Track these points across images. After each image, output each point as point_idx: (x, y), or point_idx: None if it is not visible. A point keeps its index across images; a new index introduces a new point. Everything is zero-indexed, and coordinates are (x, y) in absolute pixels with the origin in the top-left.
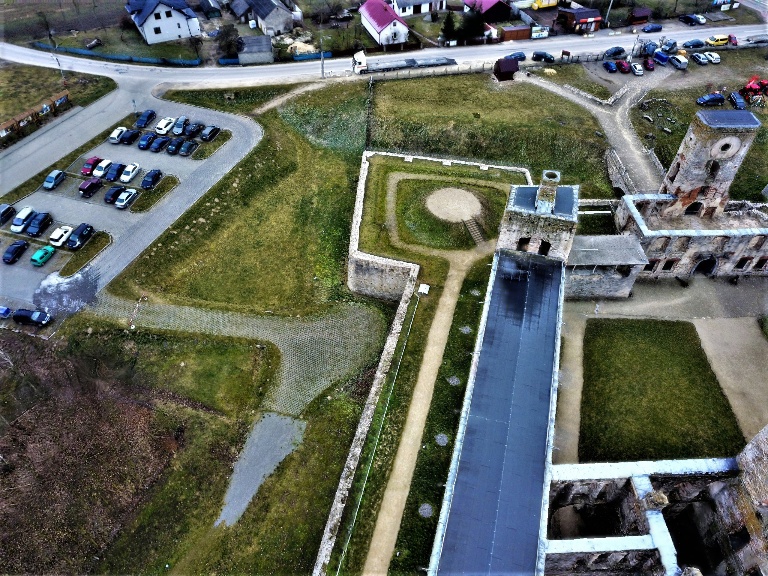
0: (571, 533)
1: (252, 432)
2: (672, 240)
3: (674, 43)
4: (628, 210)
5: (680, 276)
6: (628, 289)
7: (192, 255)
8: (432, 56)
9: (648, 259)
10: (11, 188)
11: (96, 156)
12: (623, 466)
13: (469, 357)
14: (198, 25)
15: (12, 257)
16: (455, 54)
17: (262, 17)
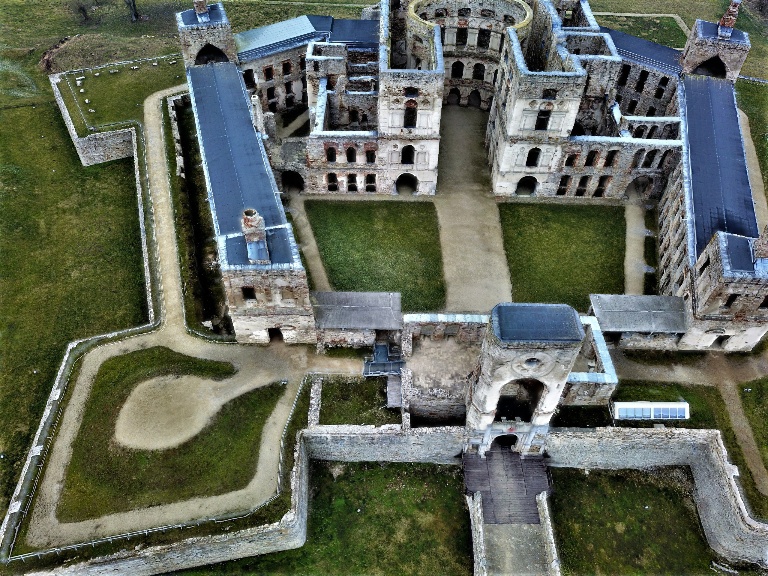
0: (629, 189)
1: None
2: None
3: None
4: None
5: None
6: None
7: None
8: None
9: None
10: None
11: None
12: (639, 141)
13: None
14: None
15: None
16: None
17: None
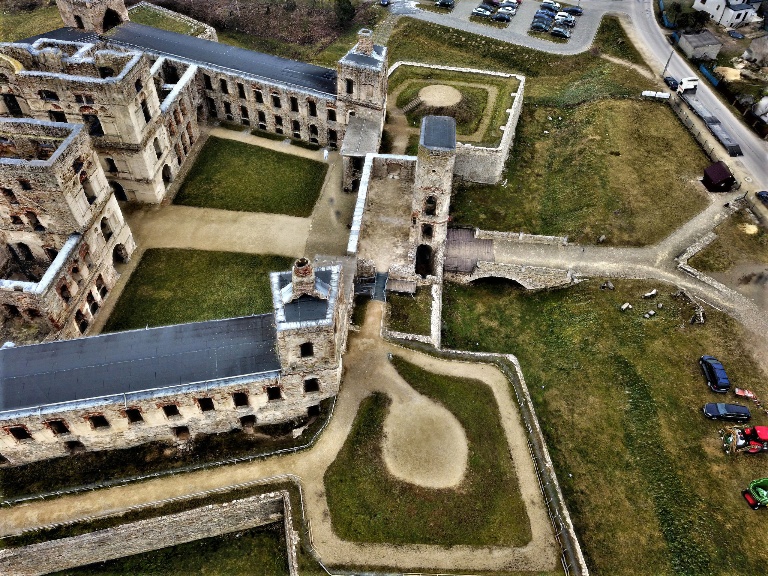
0: None
1: None
2: None
3: None
4: None
5: None
6: None
7: (434, 41)
8: (744, 141)
9: None
10: None
11: (527, 2)
12: (183, 82)
13: None
14: (730, 17)
15: None
16: (759, 159)
17: None
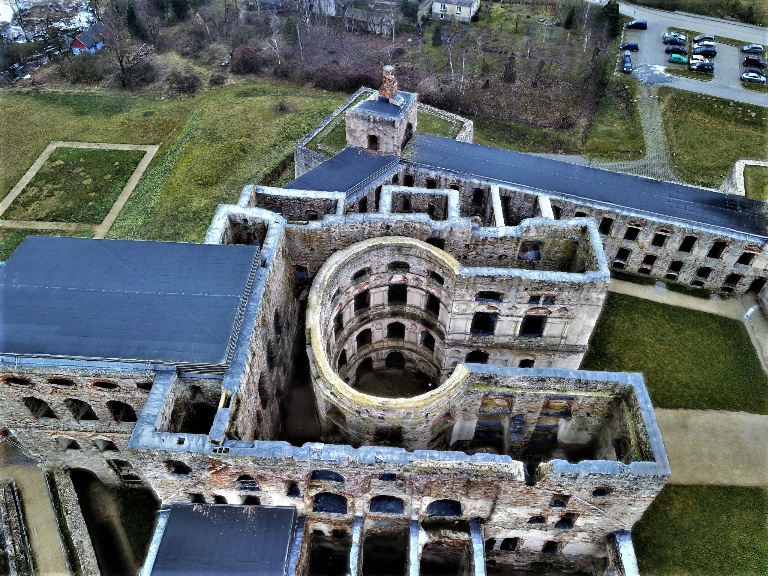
0: None
1: (574, 155)
2: None
3: None
4: None
5: None
6: None
7: (715, 118)
8: None
9: None
10: (734, 38)
11: None
12: None
13: None
14: None
15: (671, 50)
16: None
17: None
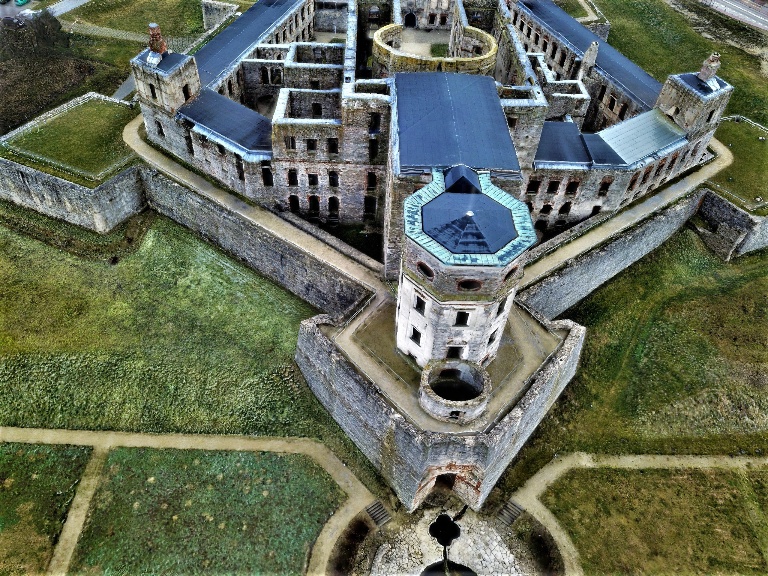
0: None
1: None
2: None
3: None
4: None
5: None
6: None
7: (113, 11)
8: None
9: None
10: None
11: None
12: None
13: None
14: None
15: None
16: None
17: None
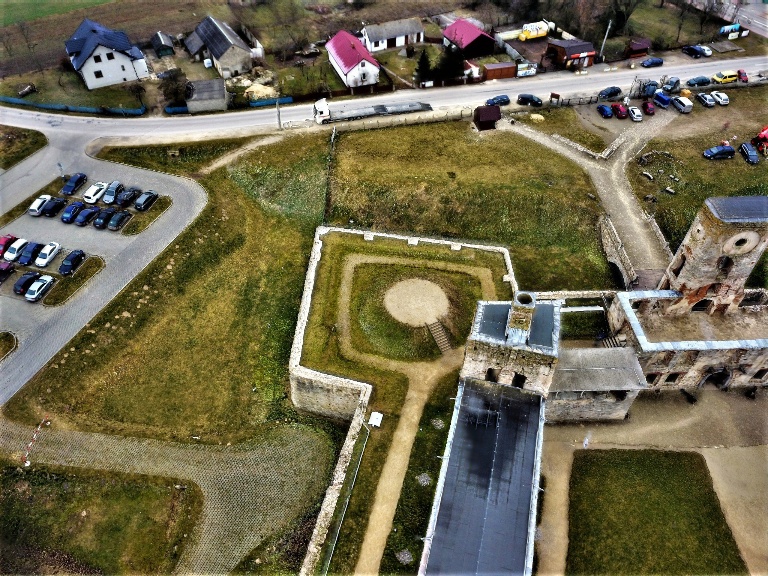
0: None
1: None
2: (677, 354)
3: (677, 81)
4: (623, 313)
5: (686, 388)
6: (624, 412)
7: (111, 360)
8: (405, 100)
9: (648, 373)
10: None
11: (12, 232)
12: None
13: (425, 521)
14: (145, 66)
15: None
16: (431, 97)
17: (216, 57)
